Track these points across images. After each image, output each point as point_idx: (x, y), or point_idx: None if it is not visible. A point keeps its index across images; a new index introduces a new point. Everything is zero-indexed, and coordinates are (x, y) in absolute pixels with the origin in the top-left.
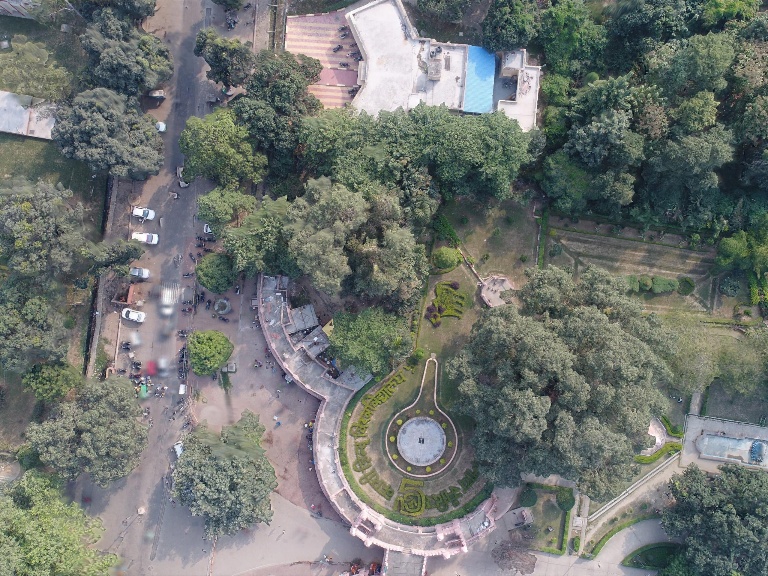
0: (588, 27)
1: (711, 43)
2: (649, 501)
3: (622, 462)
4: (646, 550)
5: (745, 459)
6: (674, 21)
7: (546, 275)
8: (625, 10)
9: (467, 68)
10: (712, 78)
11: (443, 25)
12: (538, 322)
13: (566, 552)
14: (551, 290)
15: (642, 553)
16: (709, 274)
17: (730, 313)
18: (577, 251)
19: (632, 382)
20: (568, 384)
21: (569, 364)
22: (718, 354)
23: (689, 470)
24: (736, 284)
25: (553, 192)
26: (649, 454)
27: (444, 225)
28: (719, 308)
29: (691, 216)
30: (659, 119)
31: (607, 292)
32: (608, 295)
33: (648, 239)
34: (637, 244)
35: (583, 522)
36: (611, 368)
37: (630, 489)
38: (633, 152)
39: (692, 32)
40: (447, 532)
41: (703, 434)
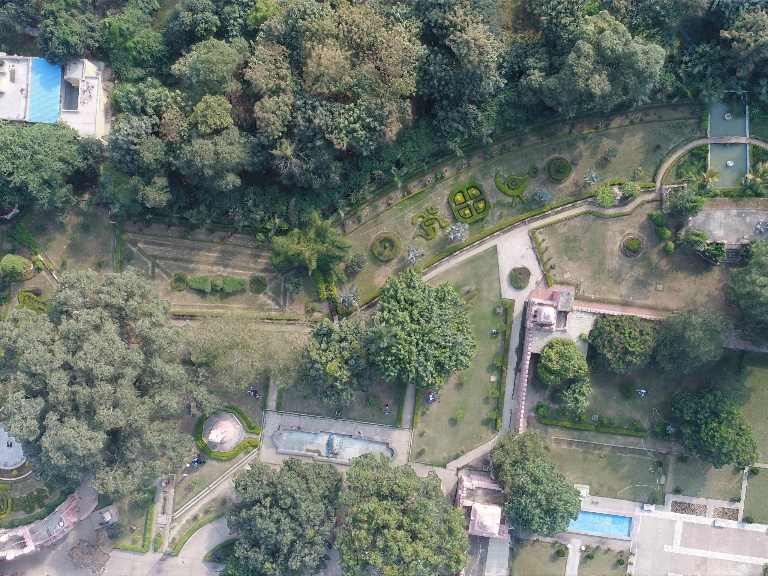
0: (142, 36)
1: (212, 48)
2: (230, 497)
3: (149, 459)
4: (226, 545)
5: (323, 452)
6: (228, 27)
7: (66, 279)
8: (173, 18)
9: (31, 80)
10: (220, 82)
11: (22, 38)
12: (47, 325)
13: (151, 549)
14: (66, 294)
15: (223, 548)
16: (278, 272)
17: (302, 310)
18: (153, 254)
19: (103, 381)
20: (51, 385)
21: (55, 365)
22: (264, 350)
23: (251, 465)
24: (297, 281)
25: (106, 198)
26: (228, 451)
27: (22, 233)
28: (291, 305)
29: (247, 216)
30: (175, 123)
31: (110, 294)
32: (111, 297)
33: (219, 240)
34: (210, 245)
35: (167, 519)
36: (82, 368)
37: (212, 486)
38: (146, 157)
39: (251, 37)
40: (12, 533)
41: (279, 429)
